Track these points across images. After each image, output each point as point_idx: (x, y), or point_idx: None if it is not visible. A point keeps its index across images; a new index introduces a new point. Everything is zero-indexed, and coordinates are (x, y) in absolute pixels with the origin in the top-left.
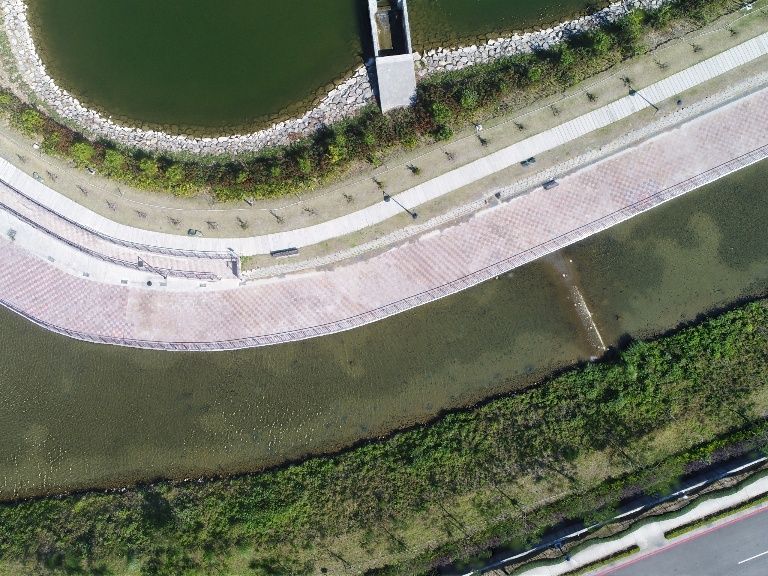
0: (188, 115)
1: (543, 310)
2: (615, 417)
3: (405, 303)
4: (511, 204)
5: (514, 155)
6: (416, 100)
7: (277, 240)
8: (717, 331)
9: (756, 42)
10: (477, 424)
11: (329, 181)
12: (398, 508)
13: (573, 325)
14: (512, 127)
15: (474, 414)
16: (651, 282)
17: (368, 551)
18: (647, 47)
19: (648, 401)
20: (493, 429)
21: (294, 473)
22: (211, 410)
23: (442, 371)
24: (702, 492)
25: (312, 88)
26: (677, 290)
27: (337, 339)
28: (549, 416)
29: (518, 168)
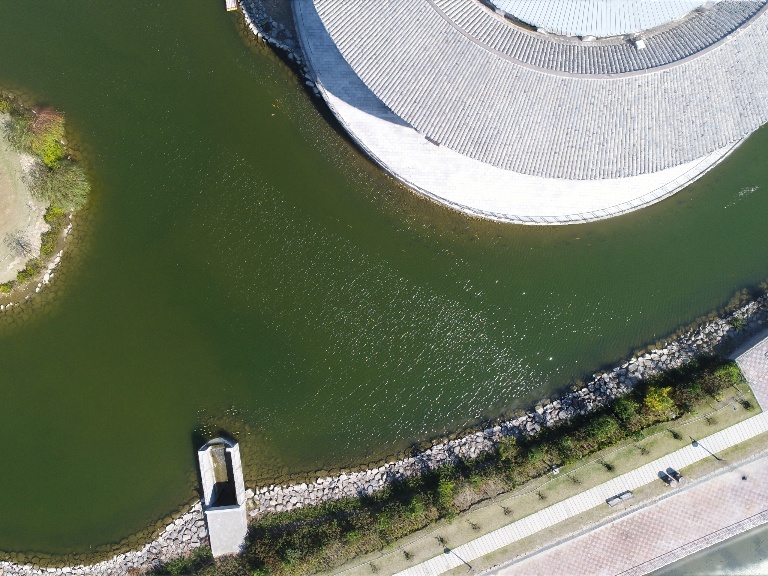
0: (35, 540)
1: None
2: None
3: None
4: None
5: None
6: None
7: None
8: None
9: (563, 505)
10: None
11: None
12: None
13: None
14: None
15: None
16: None
17: None
18: (461, 505)
19: None
20: None
21: None
22: None
23: None
24: None
25: (152, 518)
26: None
27: None
28: None
29: None
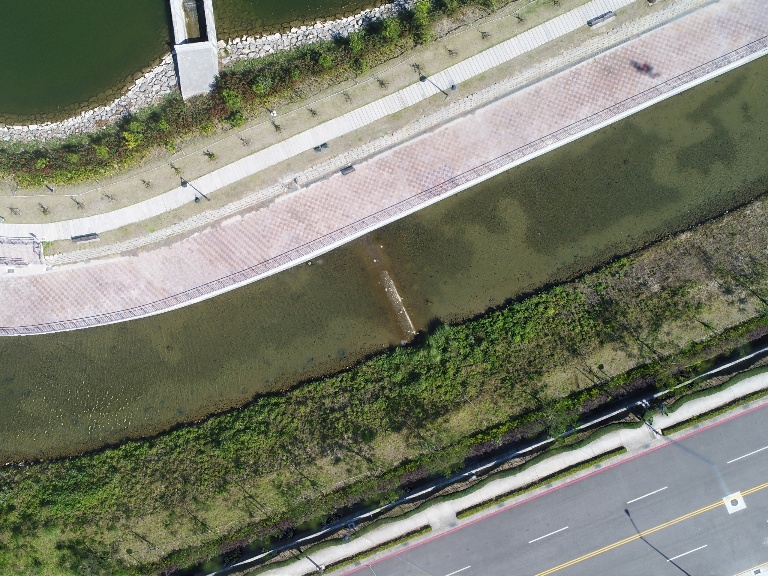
0: (2, 103)
1: (355, 295)
2: (415, 399)
3: (208, 288)
4: (310, 189)
5: (308, 141)
6: (213, 87)
7: (78, 225)
8: (520, 315)
9: (543, 28)
10: (287, 407)
11: (127, 167)
12: (202, 490)
13: (384, 310)
14: (306, 113)
15: (285, 398)
16: (460, 267)
17: (171, 532)
18: (438, 34)
19: (447, 384)
20: (301, 412)
21: (110, 456)
22: (32, 395)
23: (257, 356)
24: (491, 472)
25: (122, 76)
26: (486, 275)
27: (154, 324)
28: (354, 399)
29: (312, 154)
